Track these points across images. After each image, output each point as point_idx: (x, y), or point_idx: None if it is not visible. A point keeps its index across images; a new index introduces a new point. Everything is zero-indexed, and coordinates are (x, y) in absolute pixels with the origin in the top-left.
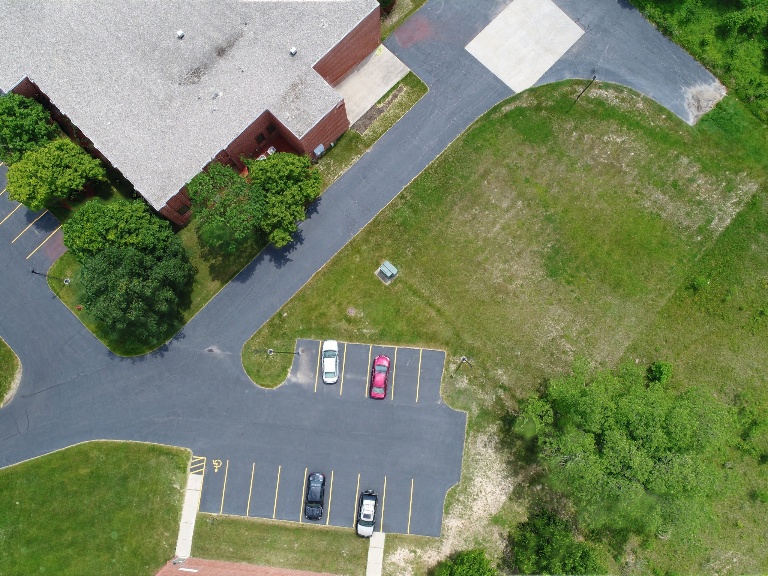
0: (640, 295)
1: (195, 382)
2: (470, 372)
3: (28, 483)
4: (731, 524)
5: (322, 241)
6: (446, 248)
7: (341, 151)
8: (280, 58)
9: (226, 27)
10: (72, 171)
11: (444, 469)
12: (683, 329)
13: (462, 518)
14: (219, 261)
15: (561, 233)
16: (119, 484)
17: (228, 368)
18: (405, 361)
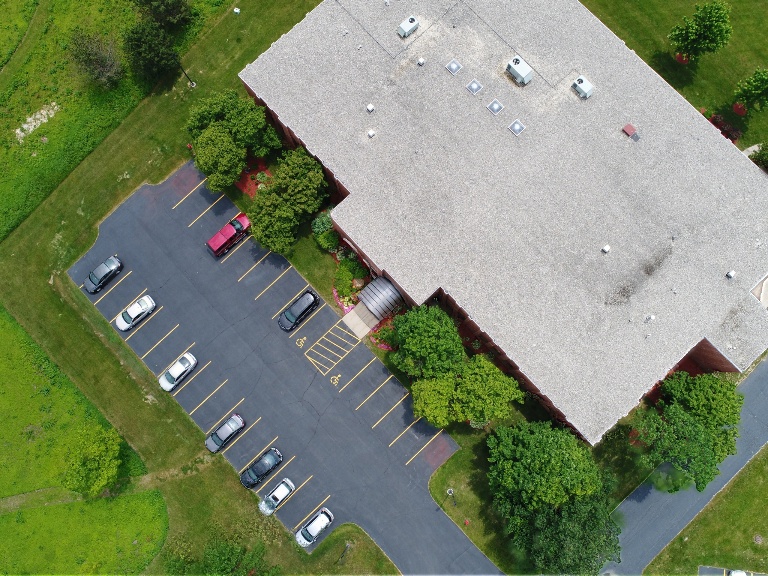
0: None
1: None
2: None
3: None
4: None
5: None
6: None
7: None
8: (715, 280)
9: (653, 242)
10: (501, 399)
11: None
12: None
13: None
14: (614, 477)
15: None
16: None
17: None
18: None
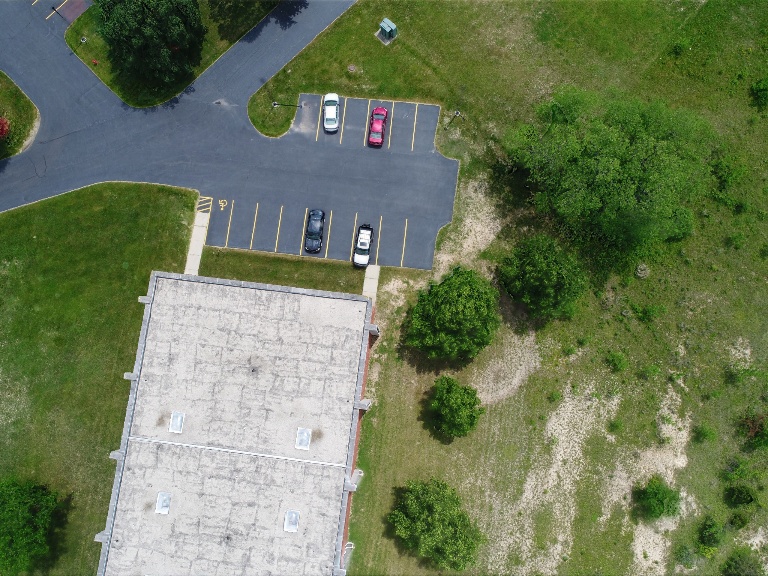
0: (625, 59)
1: (203, 131)
2: (463, 125)
3: (45, 219)
4: (706, 268)
5: (325, 6)
6: (442, 13)
7: None
8: None
9: None
10: None
11: (437, 210)
12: (665, 90)
13: (453, 253)
14: (228, 22)
15: (552, 2)
16: (131, 220)
17: (235, 119)
18: (402, 114)
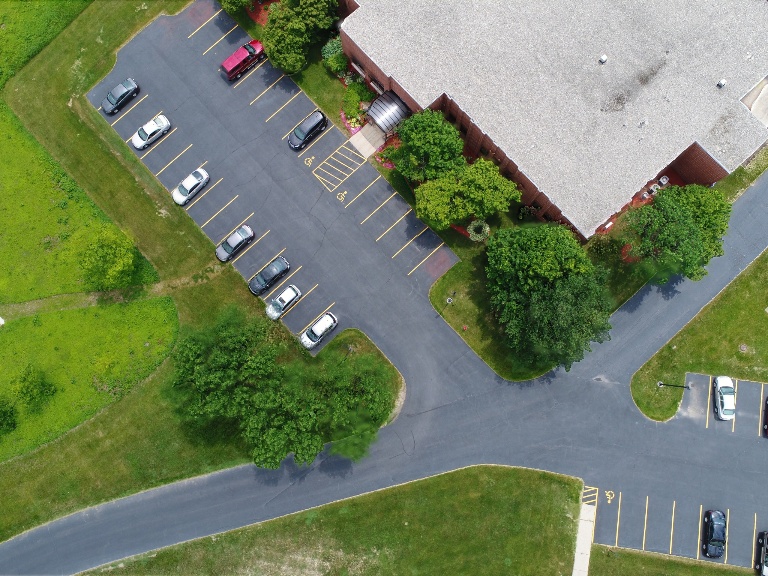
0: None
1: (584, 411)
2: None
3: (417, 504)
4: None
5: (710, 274)
6: None
7: (725, 183)
8: (706, 89)
9: (648, 54)
10: (500, 193)
11: None
12: None
13: None
14: (607, 289)
15: None
16: (511, 510)
17: (617, 398)
18: None
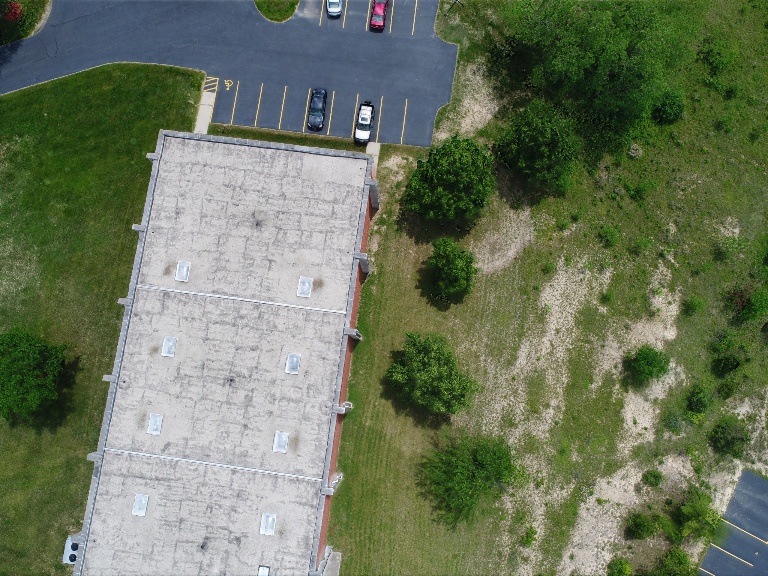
0: None
1: (210, 15)
2: (462, 11)
3: (56, 97)
4: (697, 150)
5: None
6: None
7: None
8: None
9: None
10: None
11: (436, 91)
12: None
13: (451, 132)
14: None
15: None
16: (139, 99)
17: (241, 4)
18: (403, 1)
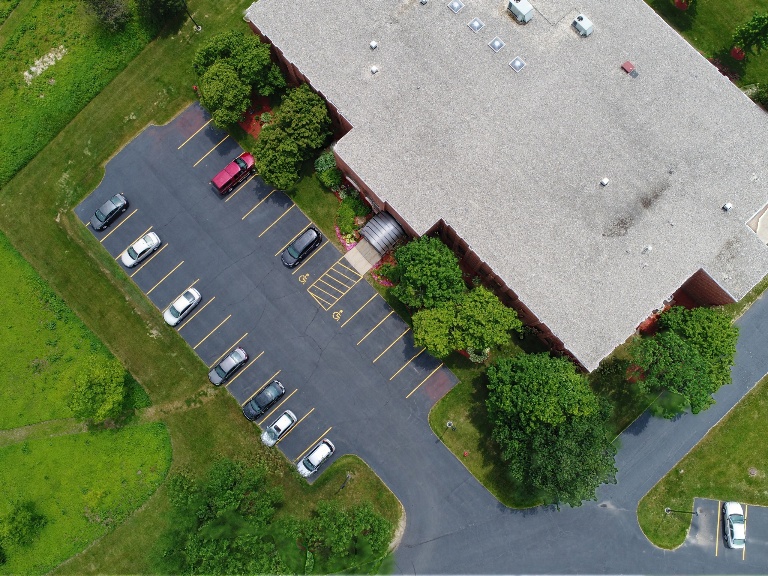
0: None
1: (590, 539)
2: None
3: None
4: None
5: (717, 394)
6: None
7: None
8: (711, 212)
9: (651, 175)
10: (500, 326)
11: None
12: None
13: None
14: (611, 411)
15: None
16: None
17: (624, 526)
18: None
